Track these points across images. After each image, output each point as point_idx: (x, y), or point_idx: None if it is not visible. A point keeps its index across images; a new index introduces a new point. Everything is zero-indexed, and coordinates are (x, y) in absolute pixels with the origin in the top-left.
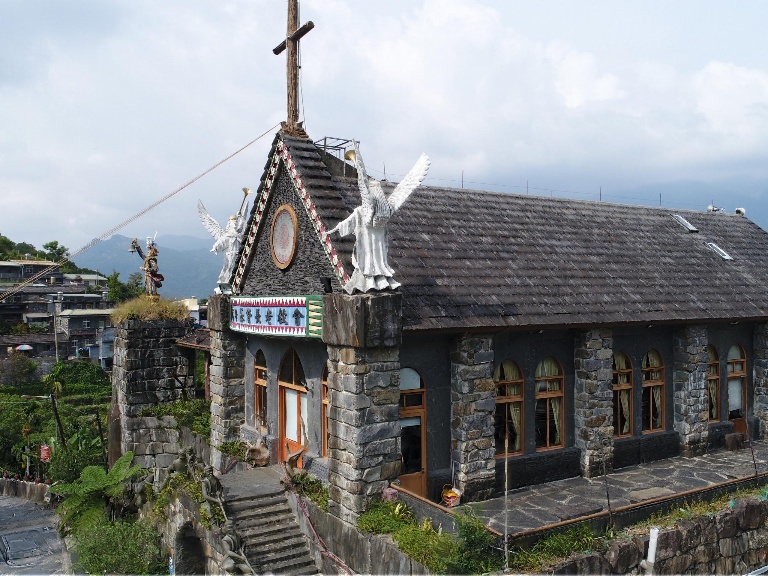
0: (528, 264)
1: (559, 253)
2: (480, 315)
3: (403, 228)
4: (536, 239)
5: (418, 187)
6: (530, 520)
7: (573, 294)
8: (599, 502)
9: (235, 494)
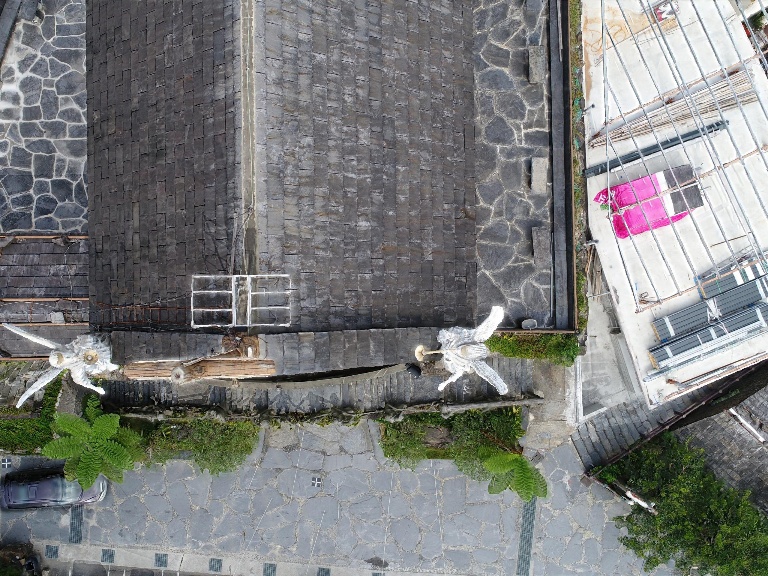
0: (402, 114)
1: (381, 40)
2: (465, 242)
3: (353, 248)
4: (357, 50)
5: (263, 163)
6: (500, 251)
7: (442, 98)
8: (496, 182)
9: (330, 395)
